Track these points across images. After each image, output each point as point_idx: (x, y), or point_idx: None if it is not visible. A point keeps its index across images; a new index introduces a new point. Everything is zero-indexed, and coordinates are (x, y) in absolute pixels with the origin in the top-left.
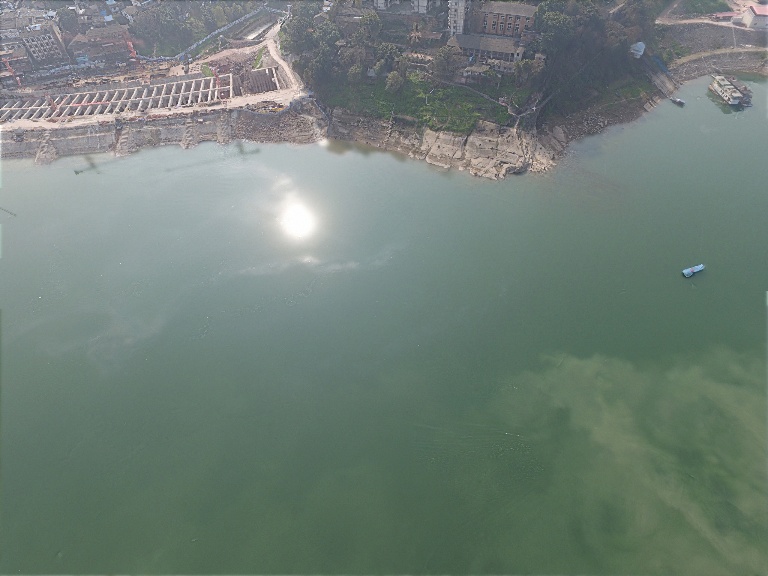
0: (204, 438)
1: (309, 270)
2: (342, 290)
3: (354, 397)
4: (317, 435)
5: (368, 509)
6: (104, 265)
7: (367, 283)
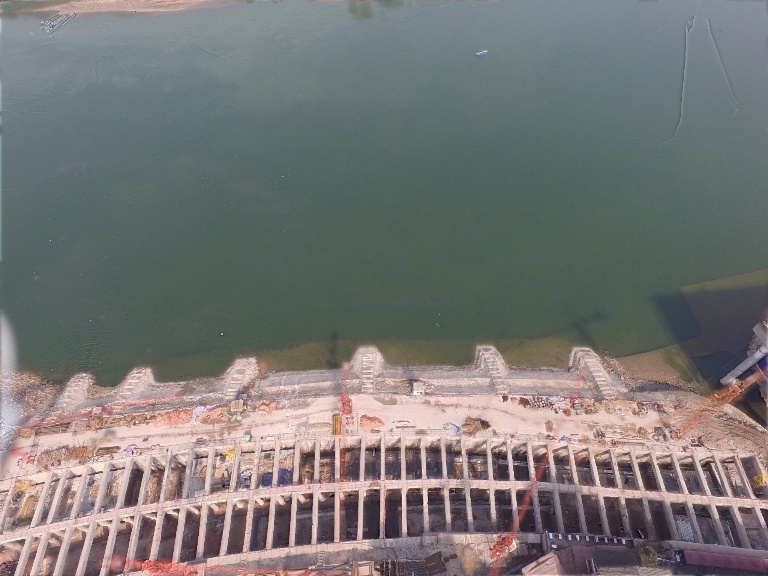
0: (157, 106)
1: (58, 192)
2: (42, 179)
3: (71, 122)
4: (99, 108)
5: None
6: (238, 202)
7: (18, 180)
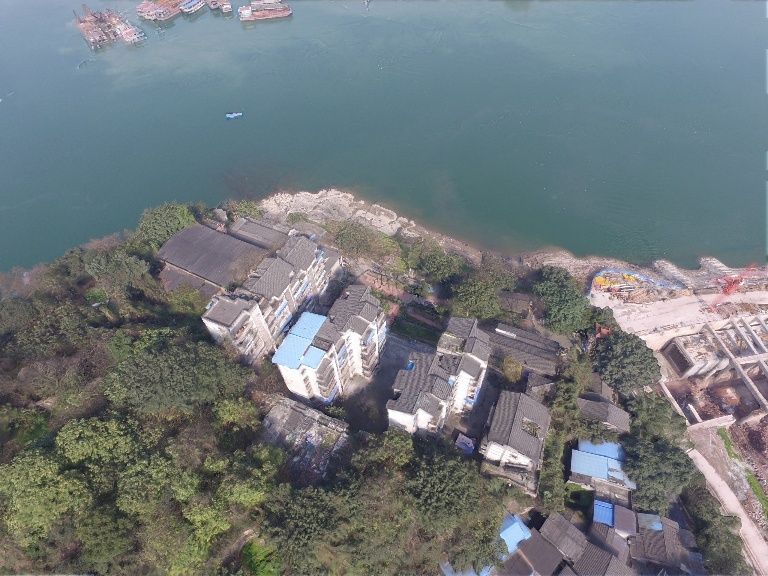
0: (531, 65)
1: (501, 130)
2: (474, 120)
3: (460, 76)
4: None
5: None
6: (670, 140)
7: (456, 121)
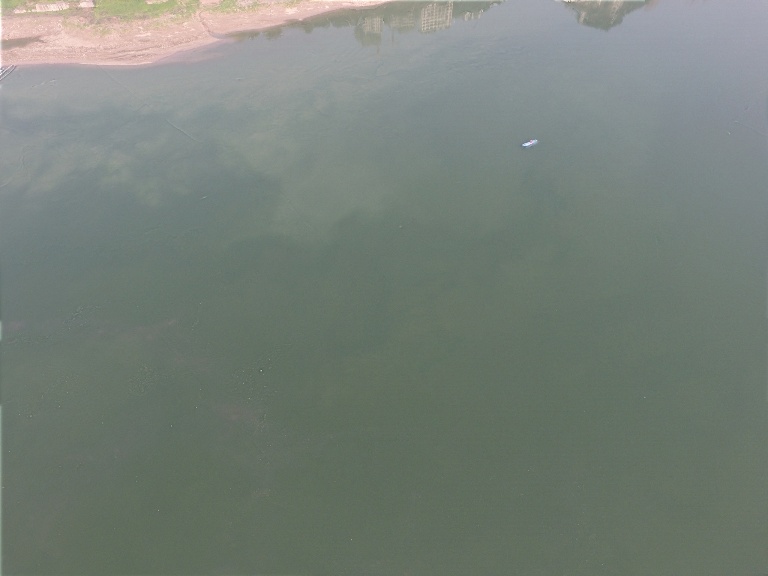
0: (95, 230)
1: None
2: None
3: None
4: (15, 230)
5: None
6: (192, 421)
7: None
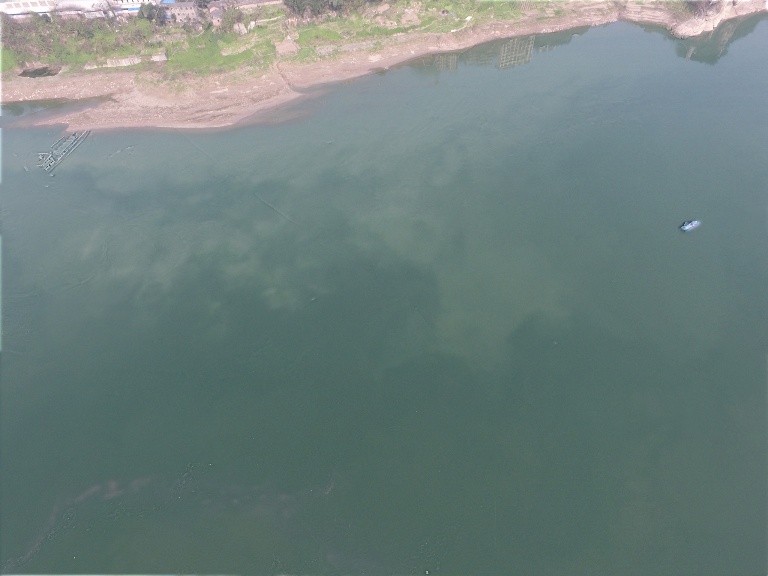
0: (197, 351)
1: None
2: None
3: (58, 381)
4: (104, 349)
5: (99, 311)
6: None
7: None
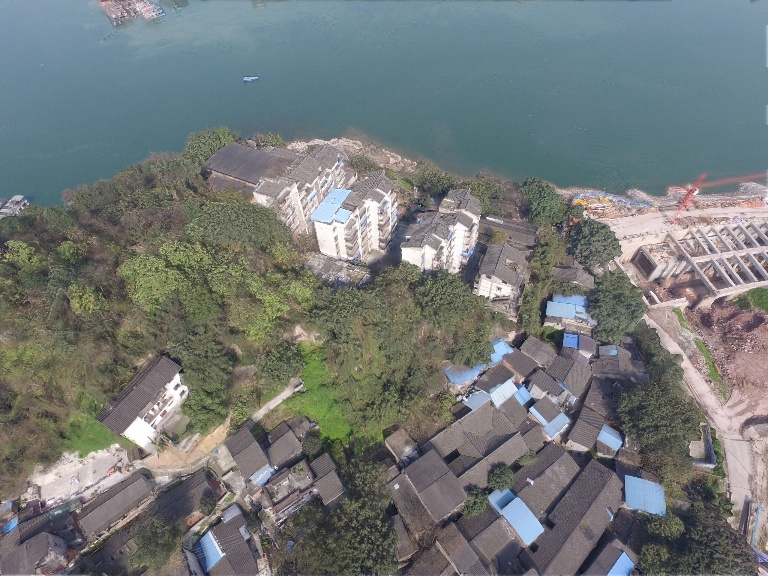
0: (521, 33)
1: (494, 88)
2: (469, 80)
3: (456, 44)
4: (471, 34)
5: None
6: (647, 94)
7: (453, 81)
